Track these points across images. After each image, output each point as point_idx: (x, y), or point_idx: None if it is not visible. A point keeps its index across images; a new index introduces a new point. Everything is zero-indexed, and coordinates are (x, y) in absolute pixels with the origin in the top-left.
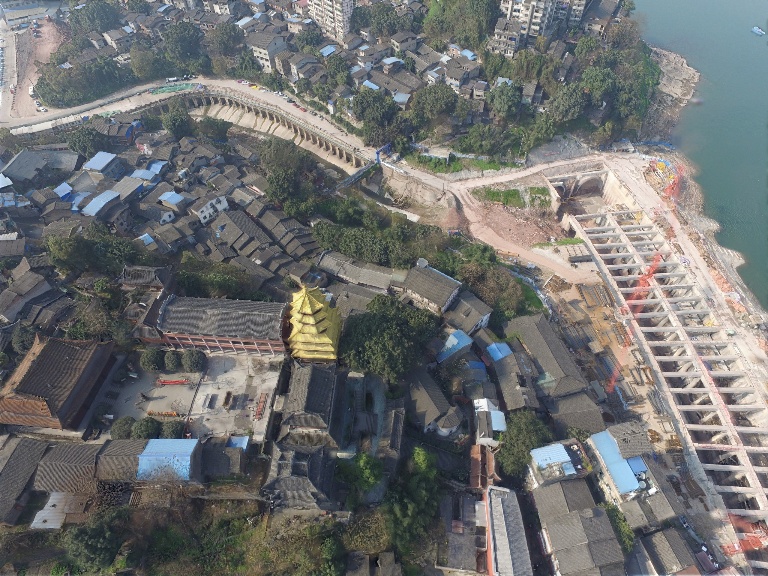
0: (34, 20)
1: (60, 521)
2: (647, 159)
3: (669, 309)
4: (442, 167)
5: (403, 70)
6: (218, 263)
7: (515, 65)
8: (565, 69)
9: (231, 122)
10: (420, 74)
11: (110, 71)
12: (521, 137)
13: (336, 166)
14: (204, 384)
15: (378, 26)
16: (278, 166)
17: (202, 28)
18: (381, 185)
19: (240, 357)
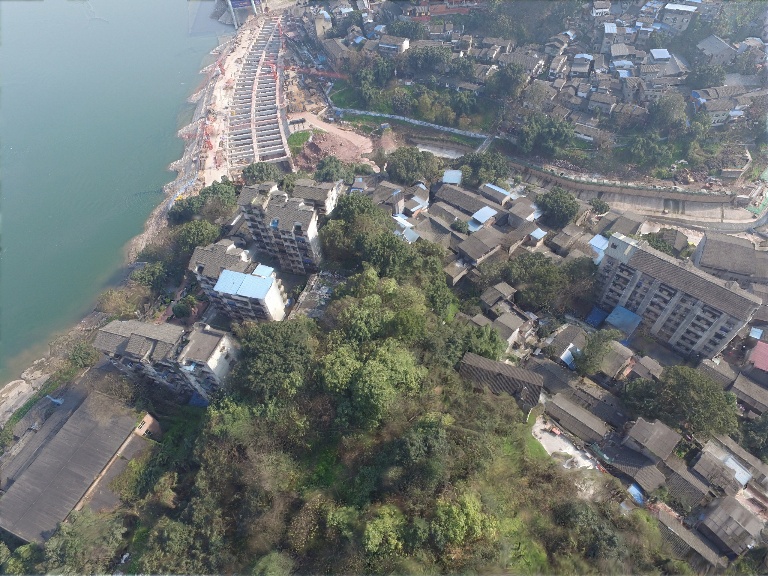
0: None
1: None
2: None
3: (253, 114)
4: None
5: None
6: (512, 28)
7: None
8: None
9: (632, 148)
10: None
11: None
12: None
13: None
14: None
15: None
16: None
17: None
18: None
19: None
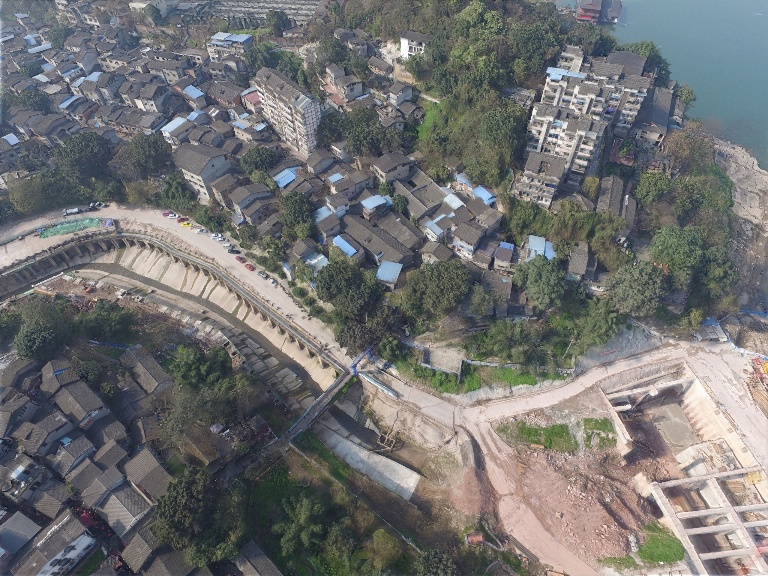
0: None
1: None
2: (747, 354)
3: None
4: (451, 385)
5: (391, 214)
6: None
7: (555, 223)
8: (628, 229)
9: (135, 313)
10: (415, 222)
11: None
12: (567, 335)
13: (295, 362)
14: None
15: (355, 144)
16: None
17: (120, 130)
18: (360, 406)
19: None
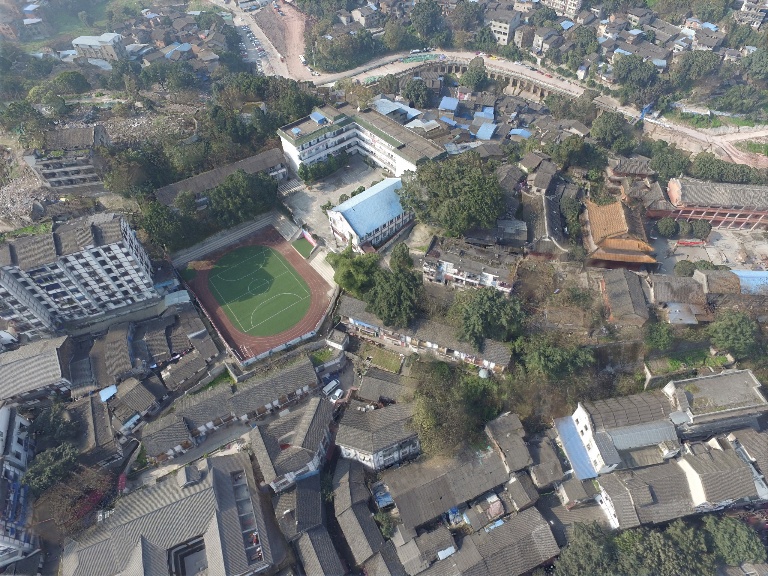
0: (274, 1)
1: (693, 319)
2: None
3: None
4: (703, 123)
5: (645, 41)
6: None
7: (766, 34)
8: None
9: None
10: (663, 44)
11: (369, 42)
12: None
13: None
14: (708, 247)
15: (614, 3)
16: (573, 116)
17: None
18: (642, 139)
19: (721, 231)
